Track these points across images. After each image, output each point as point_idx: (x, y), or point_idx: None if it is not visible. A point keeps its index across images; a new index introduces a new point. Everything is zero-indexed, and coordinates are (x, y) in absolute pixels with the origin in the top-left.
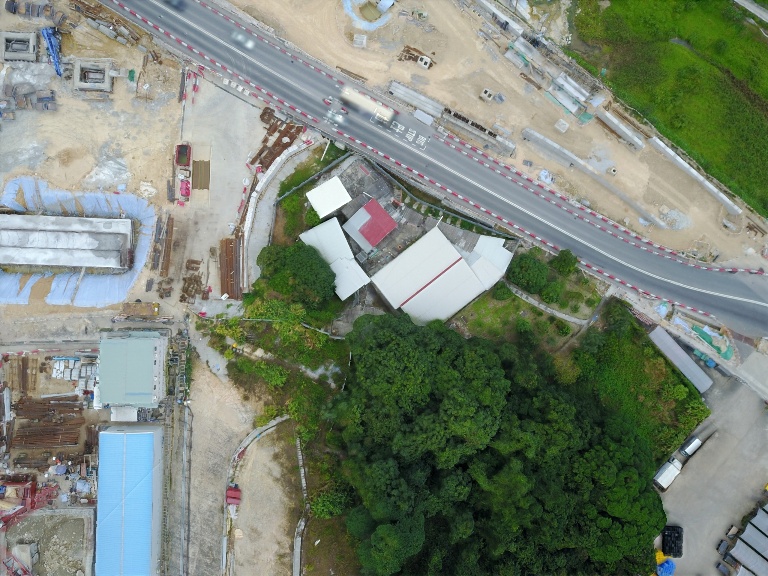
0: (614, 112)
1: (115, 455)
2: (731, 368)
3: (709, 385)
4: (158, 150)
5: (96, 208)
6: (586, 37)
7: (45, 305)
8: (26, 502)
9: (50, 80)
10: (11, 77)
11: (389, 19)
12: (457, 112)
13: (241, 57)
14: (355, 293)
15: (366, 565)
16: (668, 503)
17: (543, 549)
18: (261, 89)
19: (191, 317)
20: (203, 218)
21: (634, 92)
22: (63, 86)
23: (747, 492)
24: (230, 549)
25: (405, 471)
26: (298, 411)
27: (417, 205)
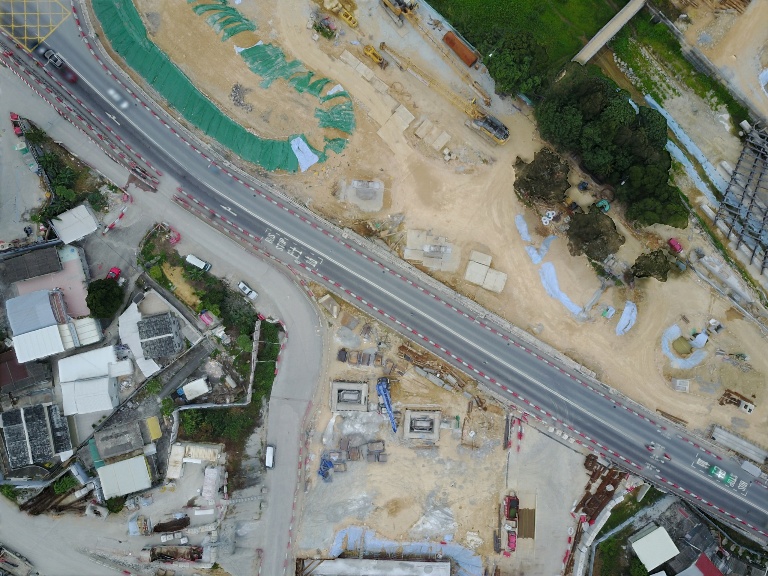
0: None
1: None
2: None
3: None
4: (484, 499)
5: (416, 550)
6: None
7: None
8: None
9: (379, 429)
10: (342, 428)
11: (705, 358)
12: None
13: (564, 402)
14: None
15: None
16: None
17: None
18: (585, 436)
19: None
20: (529, 569)
21: None
22: (390, 434)
23: None
24: None
25: None
26: None
27: (734, 547)
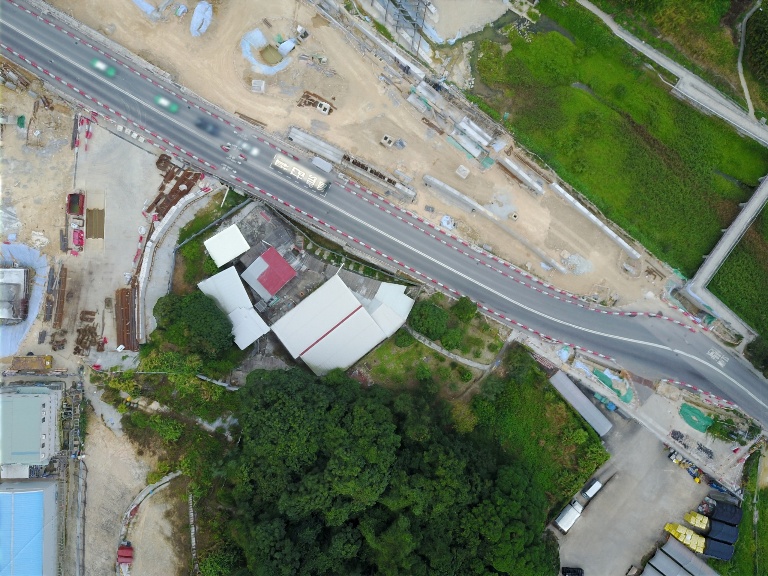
0: (516, 157)
1: (3, 515)
2: (631, 410)
3: (608, 428)
4: (50, 199)
5: None
6: (488, 81)
7: None
8: None
9: None
10: None
11: (289, 63)
12: (358, 158)
13: (136, 103)
14: (255, 342)
15: None
16: (569, 545)
17: None
18: (157, 136)
19: (85, 370)
20: (98, 268)
21: (536, 136)
22: None
23: (646, 532)
24: None
25: (294, 529)
26: (190, 467)
27: (319, 251)
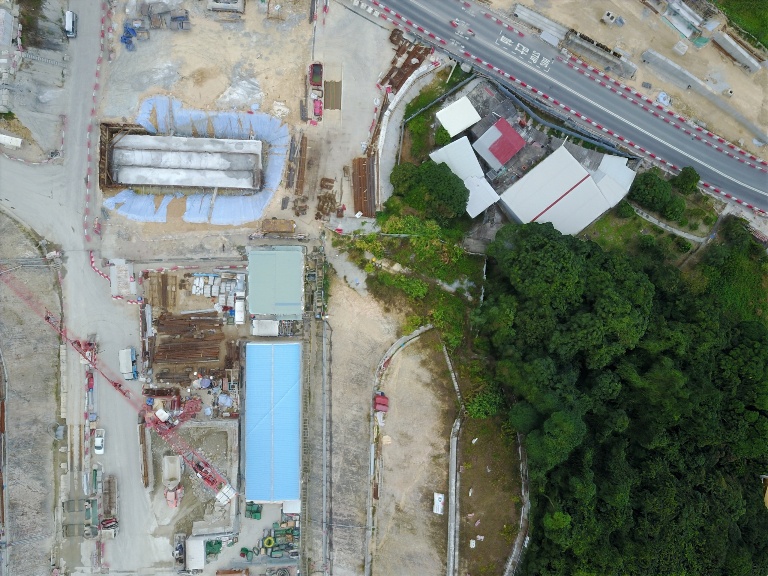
0: (729, 36)
1: (263, 366)
2: None
3: None
4: (290, 70)
5: (227, 129)
6: None
7: (183, 223)
8: (173, 414)
9: (183, 0)
10: None
11: None
12: None
13: None
14: (485, 211)
15: (535, 454)
16: None
17: (682, 449)
18: (390, 10)
19: (327, 234)
20: (335, 138)
21: (746, 17)
22: (195, 6)
23: None
24: (378, 455)
25: None
26: (443, 320)
27: (540, 127)
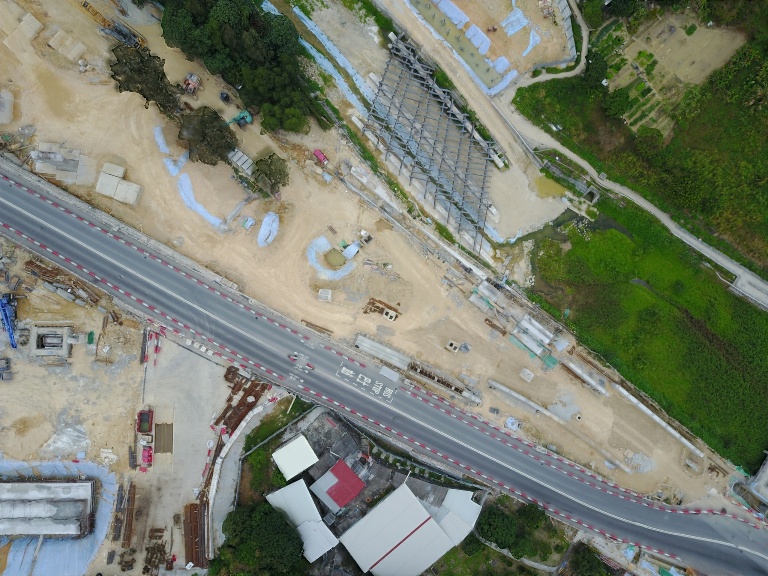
0: (578, 356)
1: None
2: None
3: None
4: (119, 415)
5: (54, 472)
6: (549, 279)
7: None
8: None
9: (5, 347)
10: None
11: (354, 268)
12: (423, 363)
13: (204, 315)
14: (323, 555)
15: None
16: None
17: None
18: (225, 348)
19: None
20: (166, 483)
21: (597, 333)
22: (19, 352)
23: None
24: None
25: None
26: None
27: (385, 455)
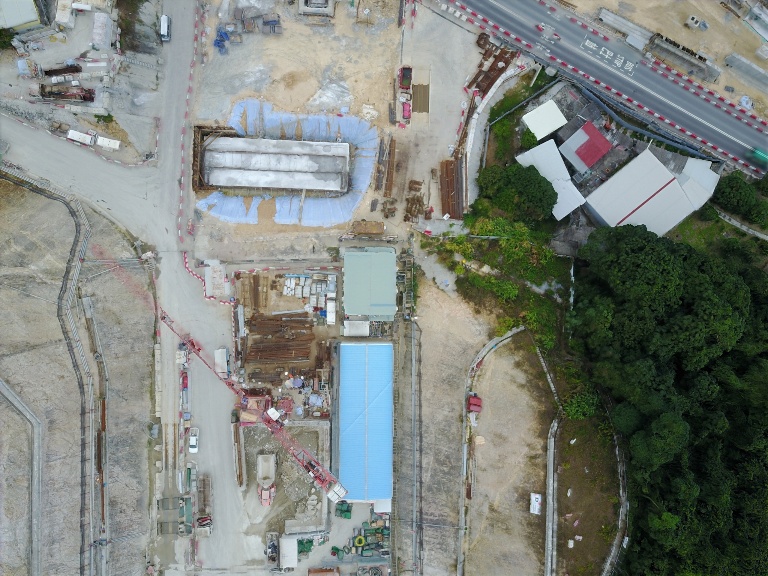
0: None
1: (357, 366)
2: None
3: None
4: (379, 74)
5: (315, 132)
6: None
7: (274, 224)
8: None
9: (274, 4)
10: (237, 1)
11: None
12: None
13: None
14: (571, 213)
15: (641, 455)
16: None
17: None
18: (477, 15)
19: (415, 236)
20: (423, 140)
21: None
22: (286, 11)
23: None
24: (471, 455)
25: None
26: (536, 321)
27: (622, 130)
